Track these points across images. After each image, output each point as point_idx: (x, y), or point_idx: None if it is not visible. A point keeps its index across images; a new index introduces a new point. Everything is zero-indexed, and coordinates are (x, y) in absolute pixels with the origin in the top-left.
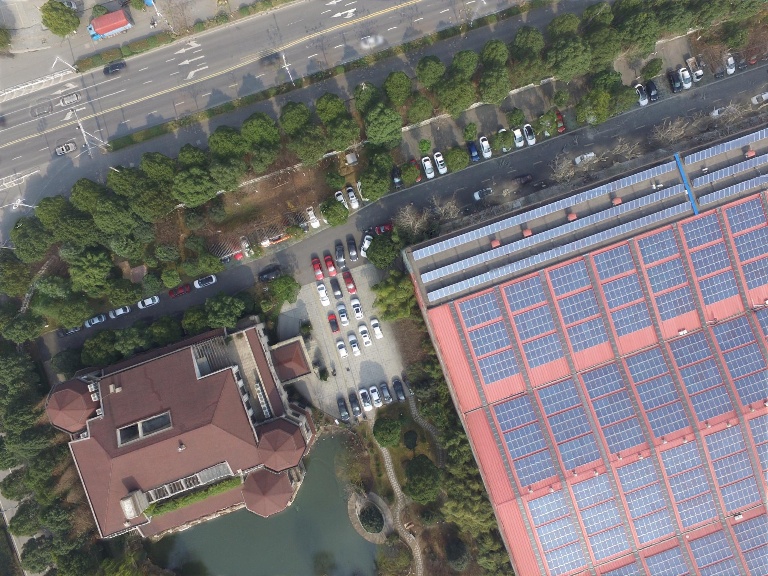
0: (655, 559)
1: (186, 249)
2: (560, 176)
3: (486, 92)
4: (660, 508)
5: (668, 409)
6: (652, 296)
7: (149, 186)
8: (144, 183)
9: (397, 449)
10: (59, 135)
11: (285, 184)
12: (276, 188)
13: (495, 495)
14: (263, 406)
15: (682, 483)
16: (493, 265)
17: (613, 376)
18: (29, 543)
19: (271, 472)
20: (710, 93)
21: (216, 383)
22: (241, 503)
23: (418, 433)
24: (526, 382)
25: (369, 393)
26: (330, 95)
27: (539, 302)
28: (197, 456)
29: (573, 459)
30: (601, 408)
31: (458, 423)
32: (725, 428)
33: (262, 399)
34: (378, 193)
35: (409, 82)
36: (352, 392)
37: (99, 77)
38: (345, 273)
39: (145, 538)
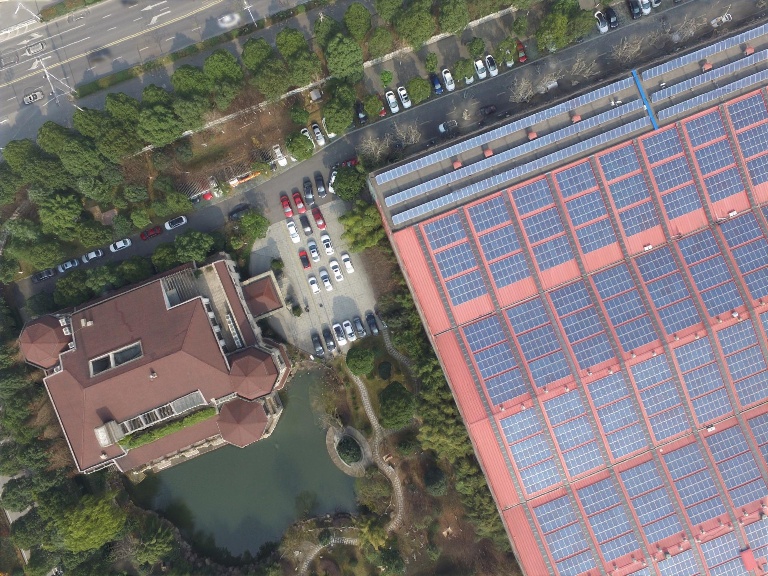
0: (630, 473)
1: (156, 192)
2: (519, 97)
3: (444, 20)
4: (632, 422)
5: (636, 323)
6: (616, 212)
7: (114, 125)
8: (109, 122)
9: (373, 382)
10: (26, 84)
11: (251, 124)
12: (242, 128)
13: (467, 415)
14: (234, 336)
15: (653, 397)
16: (456, 187)
17: (580, 293)
18: (9, 483)
19: (244, 400)
20: (670, 18)
21: (186, 312)
22: (218, 437)
23: (393, 365)
24: (494, 303)
25: (343, 327)
26: (290, 29)
27: (503, 222)
28: (169, 385)
29: (543, 376)
30: (569, 325)
31: (430, 350)
32: (694, 340)
33: (233, 329)
34: (341, 123)
35: (368, 14)
36: (326, 327)
37: (63, 26)
38: (314, 209)
39: (127, 480)
